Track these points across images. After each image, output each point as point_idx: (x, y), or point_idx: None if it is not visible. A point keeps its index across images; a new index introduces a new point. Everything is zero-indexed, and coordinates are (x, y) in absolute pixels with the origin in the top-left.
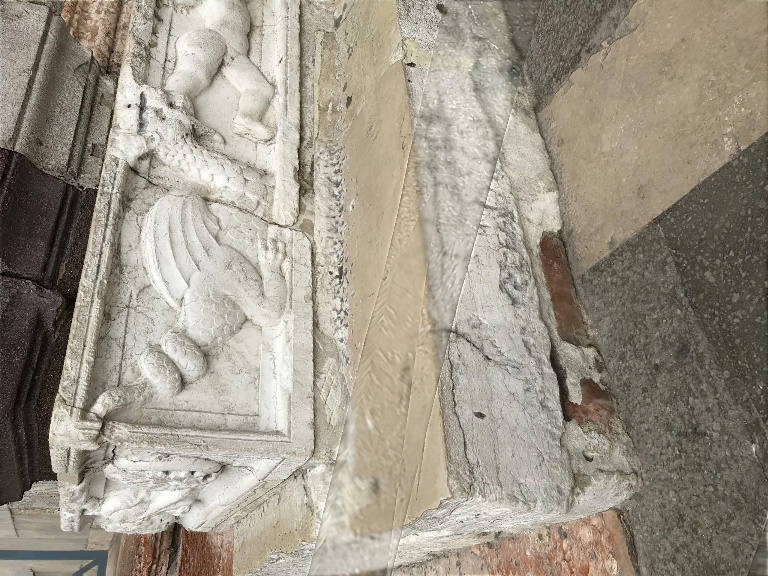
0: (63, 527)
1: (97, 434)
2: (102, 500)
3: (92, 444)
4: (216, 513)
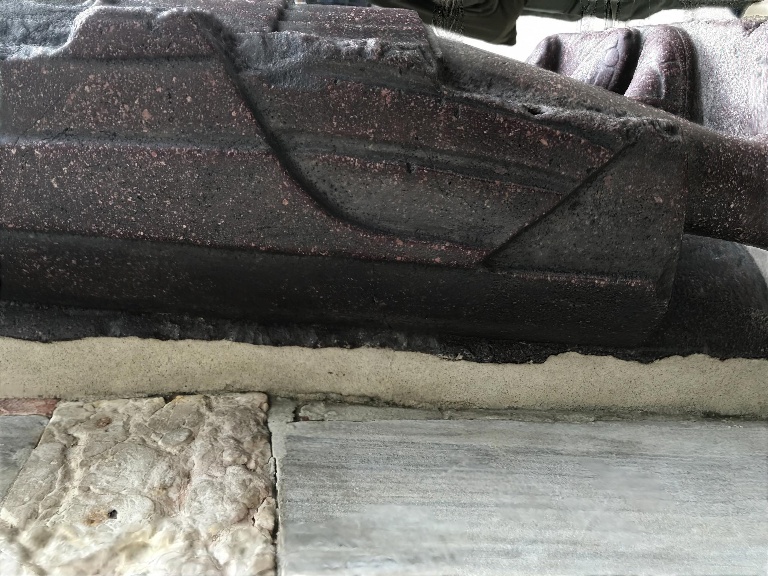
0: None
1: None
2: None
3: None
4: None
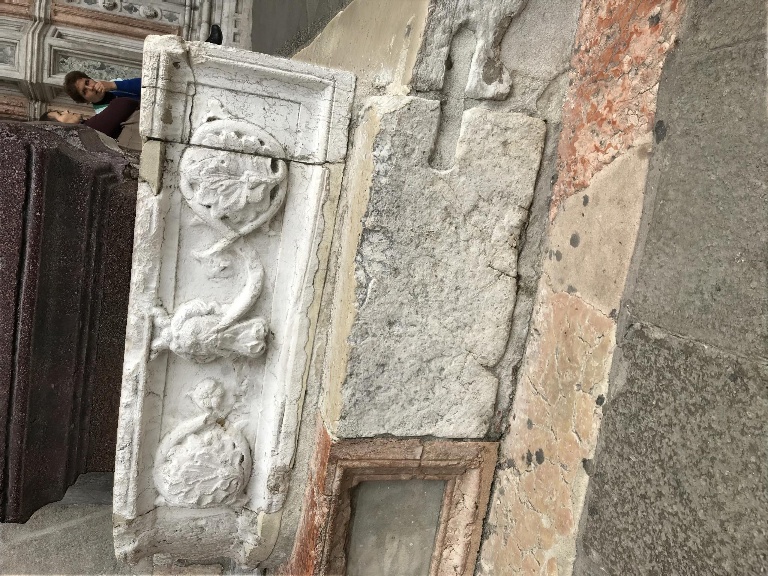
0: (122, 434)
1: (181, 39)
2: (172, 316)
3: (178, 46)
4: (294, 343)
